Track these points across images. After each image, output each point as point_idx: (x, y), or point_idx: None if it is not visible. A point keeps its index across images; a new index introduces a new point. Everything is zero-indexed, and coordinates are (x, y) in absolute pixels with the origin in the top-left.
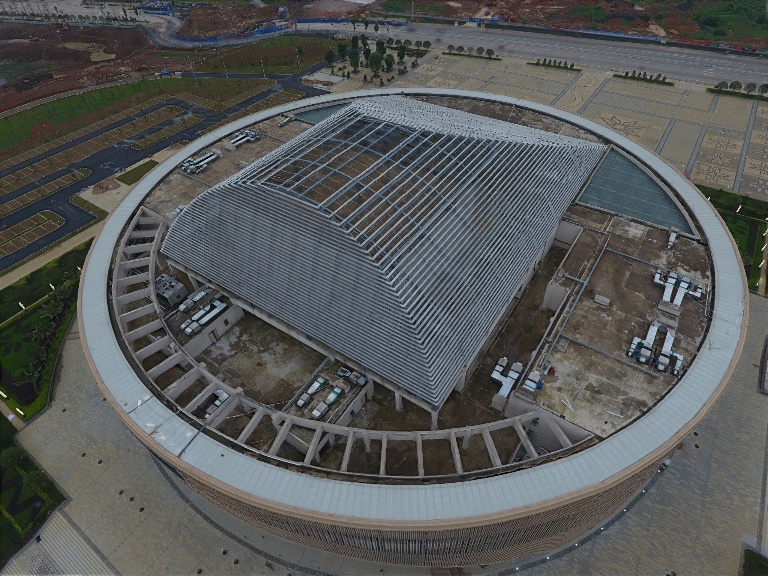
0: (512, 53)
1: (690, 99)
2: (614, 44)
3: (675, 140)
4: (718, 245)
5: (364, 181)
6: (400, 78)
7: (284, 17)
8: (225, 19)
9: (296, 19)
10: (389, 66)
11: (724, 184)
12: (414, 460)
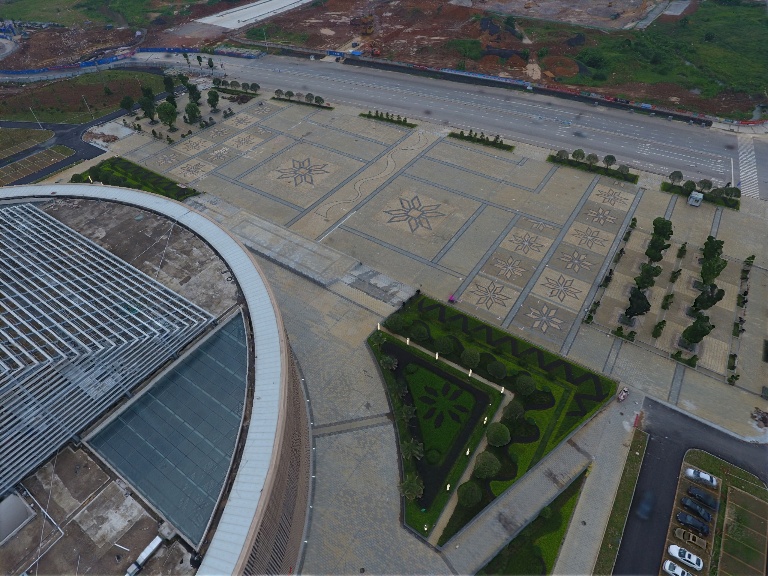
0: (351, 99)
1: (522, 171)
2: (474, 89)
3: (471, 236)
4: (208, 575)
5: None
6: (200, 133)
7: (134, 43)
8: (70, 44)
9: (143, 47)
10: (192, 117)
11: (496, 313)
12: None
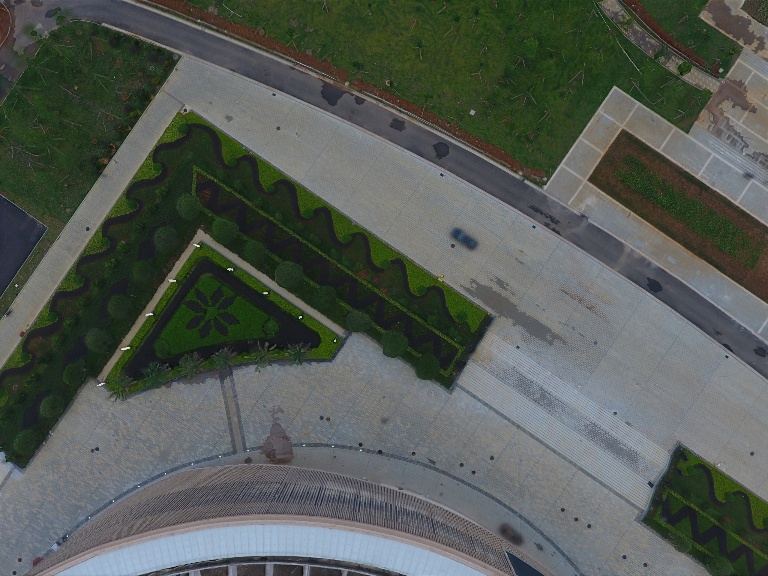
0: None
1: None
2: None
3: None
4: None
5: None
6: None
7: None
8: None
9: None
10: None
11: None
12: (283, 571)
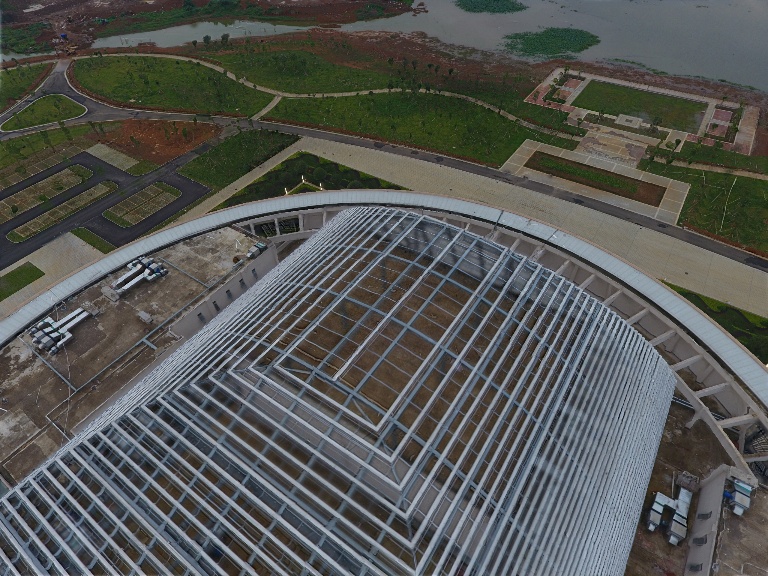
0: None
1: None
2: None
3: None
4: None
5: (375, 255)
6: None
7: None
8: None
9: None
10: None
11: None
12: None
